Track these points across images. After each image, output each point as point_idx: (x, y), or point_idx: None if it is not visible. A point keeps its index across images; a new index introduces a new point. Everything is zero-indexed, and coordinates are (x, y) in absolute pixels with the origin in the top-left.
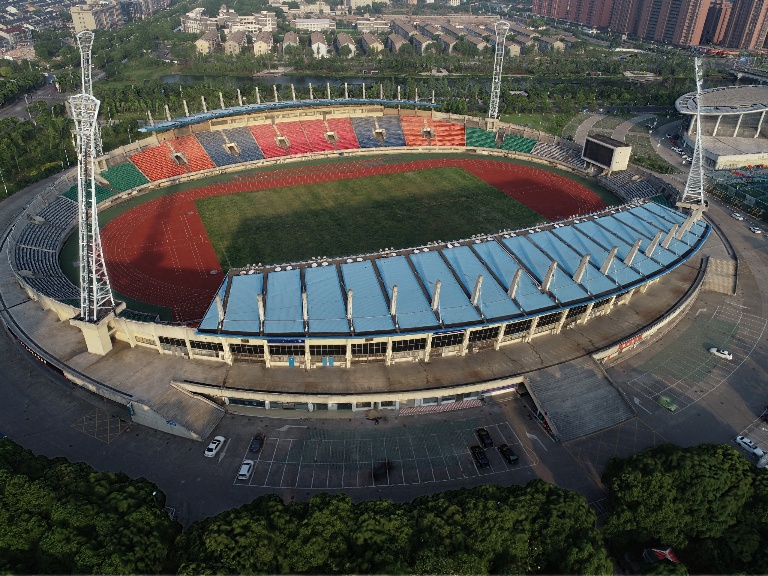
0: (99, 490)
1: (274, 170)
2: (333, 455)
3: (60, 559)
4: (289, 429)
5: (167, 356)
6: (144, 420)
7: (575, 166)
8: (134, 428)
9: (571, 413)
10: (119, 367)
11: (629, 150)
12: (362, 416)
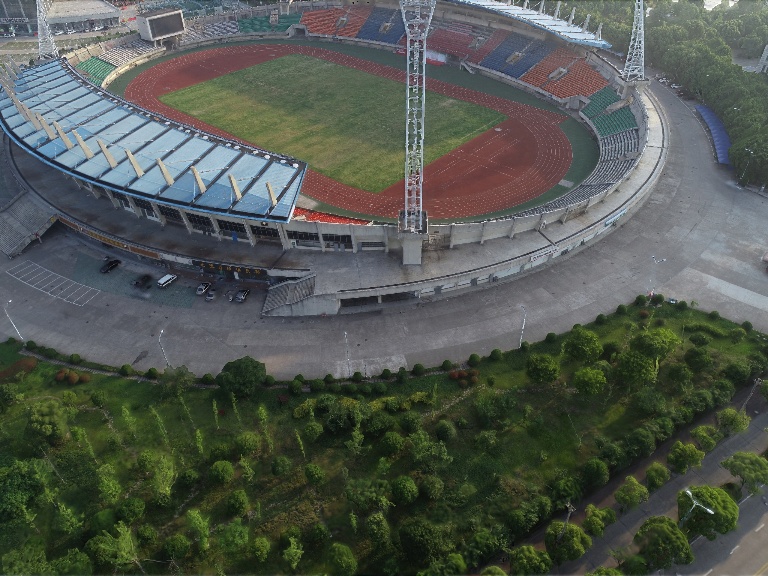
0: None
1: None
2: None
3: None
4: None
5: None
6: None
7: (155, 50)
8: None
9: None
10: None
11: None
12: None
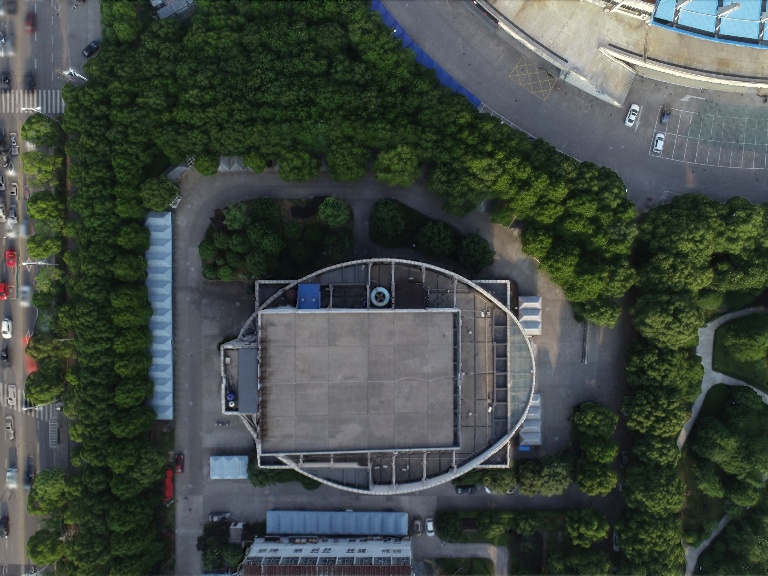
0: (595, 189)
1: None
2: (725, 133)
3: (576, 233)
4: (690, 100)
5: (587, 5)
6: (573, 82)
7: None
8: (562, 86)
9: None
10: (546, 18)
11: None
12: (754, 91)
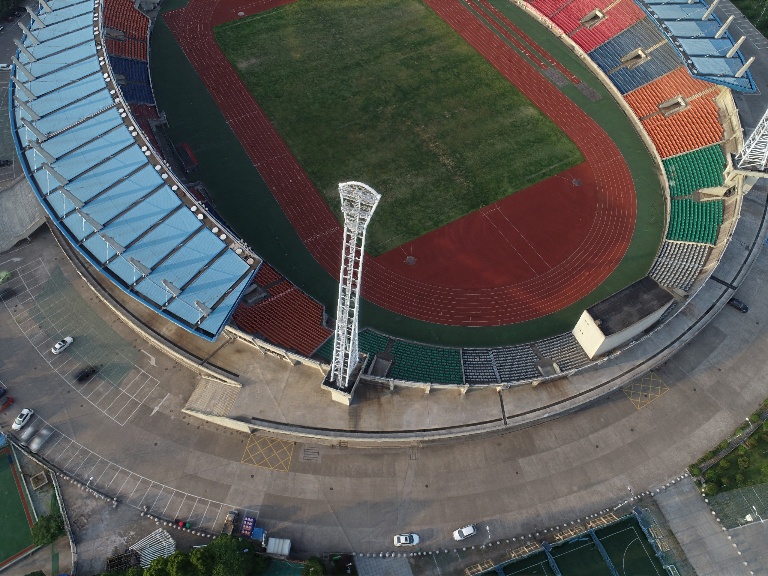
0: None
1: (493, 5)
2: None
3: None
4: None
5: None
6: None
7: None
8: None
9: (1, 207)
10: None
11: (601, 338)
12: None
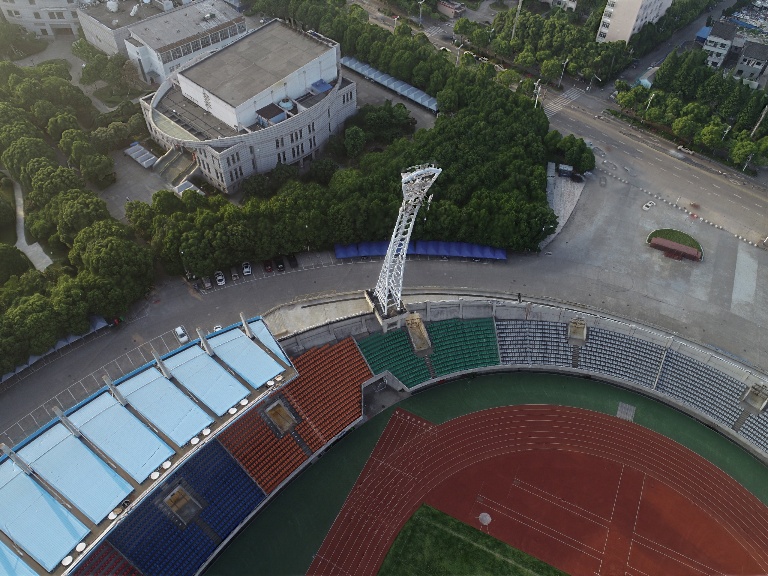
0: None
1: None
2: None
3: None
4: None
5: None
6: None
7: None
8: None
9: None
10: None
11: None
12: None
